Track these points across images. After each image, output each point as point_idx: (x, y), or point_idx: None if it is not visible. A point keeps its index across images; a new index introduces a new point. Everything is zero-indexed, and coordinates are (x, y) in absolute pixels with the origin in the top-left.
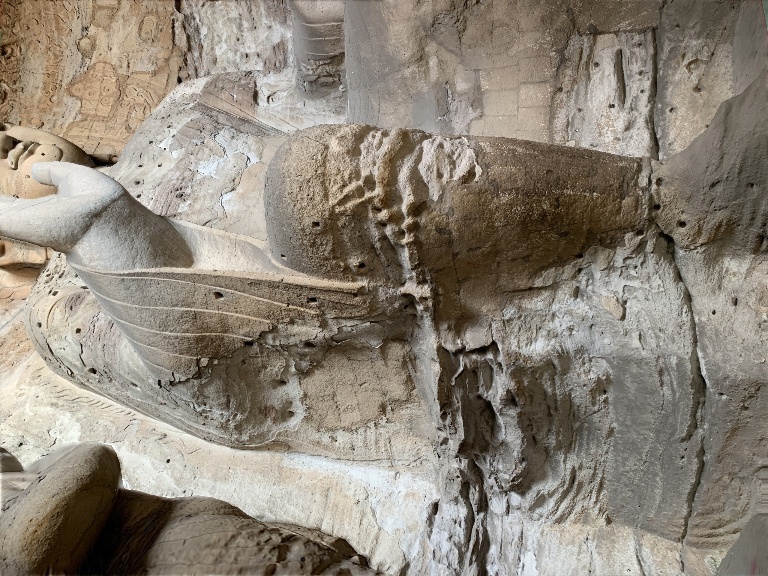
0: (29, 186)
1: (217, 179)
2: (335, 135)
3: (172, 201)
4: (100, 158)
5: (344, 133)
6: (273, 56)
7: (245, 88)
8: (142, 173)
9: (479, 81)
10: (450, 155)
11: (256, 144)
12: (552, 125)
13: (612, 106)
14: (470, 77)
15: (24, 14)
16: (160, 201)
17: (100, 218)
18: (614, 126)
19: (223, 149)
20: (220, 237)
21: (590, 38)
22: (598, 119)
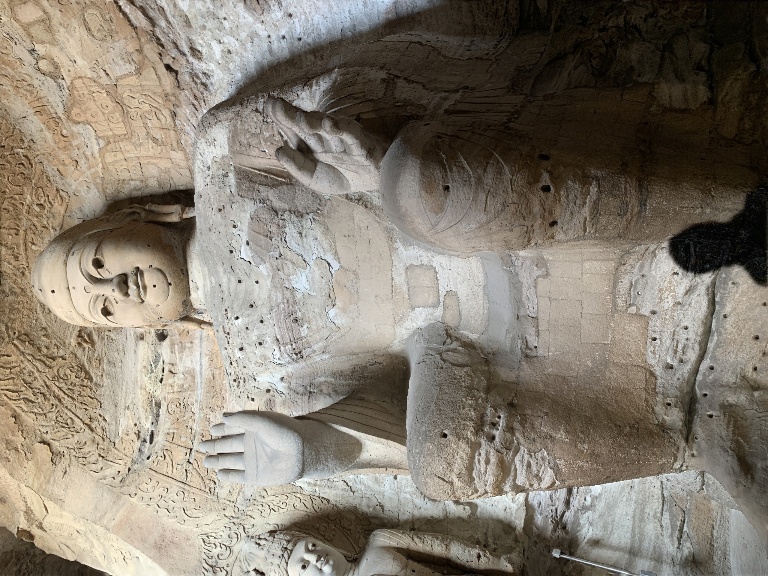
0: (163, 310)
1: (315, 296)
2: (453, 471)
3: (292, 327)
4: (173, 222)
5: (459, 469)
6: None
7: (273, 142)
8: (247, 293)
9: None
10: None
11: (326, 239)
12: (615, 289)
13: (676, 273)
14: (532, 252)
15: None
16: (283, 328)
17: (305, 471)
18: (675, 292)
19: (302, 258)
20: None
21: (658, 243)
22: (660, 285)
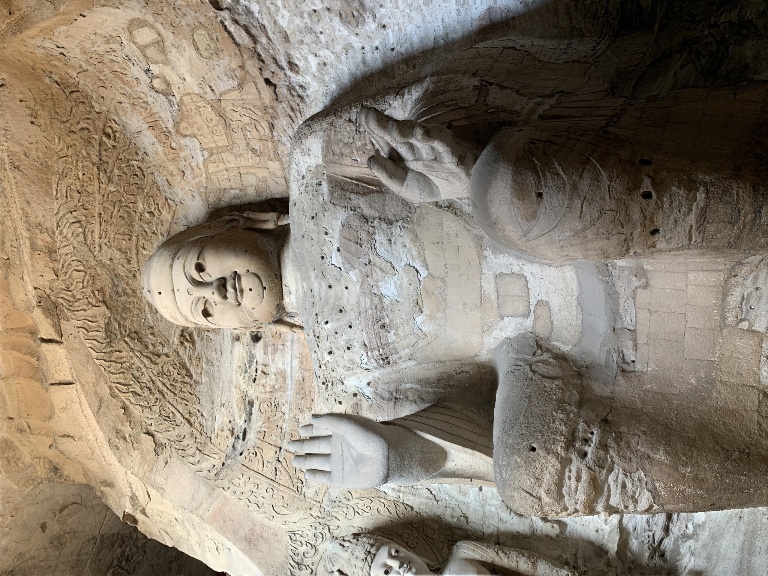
0: (258, 313)
1: (403, 303)
2: (542, 486)
3: (380, 333)
4: None
5: (548, 484)
6: (346, 6)
7: (364, 151)
8: (337, 298)
9: (642, 265)
10: (632, 495)
11: (414, 246)
12: (725, 303)
13: None
14: (631, 261)
15: (89, 89)
16: (370, 333)
17: (389, 476)
18: None
19: (390, 265)
20: (461, 451)
21: None
22: None
